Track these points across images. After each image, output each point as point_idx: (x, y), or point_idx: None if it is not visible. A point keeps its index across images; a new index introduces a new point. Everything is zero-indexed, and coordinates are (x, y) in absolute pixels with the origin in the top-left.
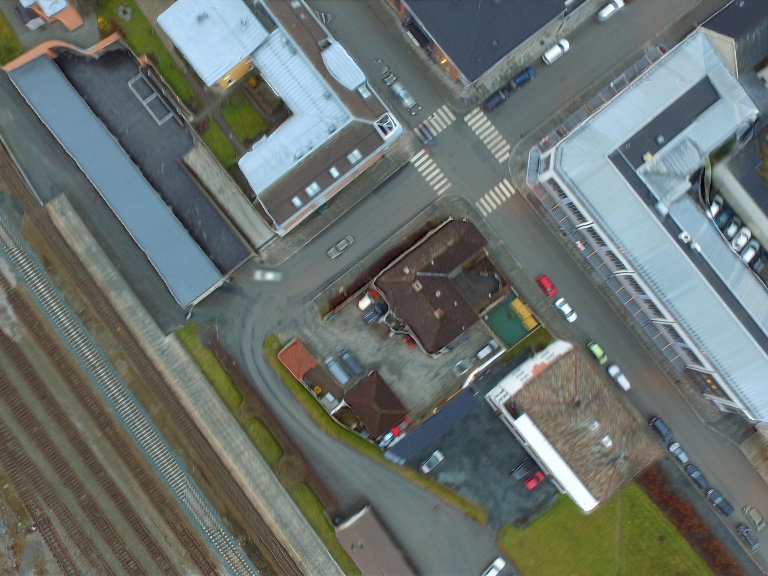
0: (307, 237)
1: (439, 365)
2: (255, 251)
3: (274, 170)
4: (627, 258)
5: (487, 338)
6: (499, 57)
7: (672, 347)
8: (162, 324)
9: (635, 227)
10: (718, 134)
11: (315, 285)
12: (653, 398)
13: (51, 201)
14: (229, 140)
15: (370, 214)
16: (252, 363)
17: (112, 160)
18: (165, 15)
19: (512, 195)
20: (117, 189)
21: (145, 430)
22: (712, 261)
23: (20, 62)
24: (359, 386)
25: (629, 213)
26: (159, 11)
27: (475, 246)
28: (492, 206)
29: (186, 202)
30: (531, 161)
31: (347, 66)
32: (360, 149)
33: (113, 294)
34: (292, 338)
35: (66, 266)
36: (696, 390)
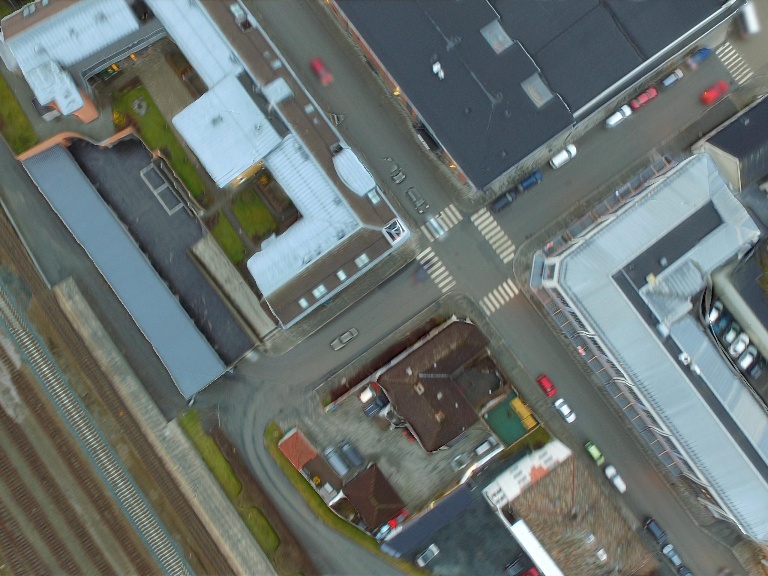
0: (311, 328)
1: (438, 459)
2: (259, 340)
3: (282, 273)
4: (627, 372)
5: (486, 435)
6: (507, 167)
7: (669, 454)
8: (164, 410)
9: (636, 345)
10: (720, 255)
11: (318, 375)
12: (648, 499)
13: (59, 284)
14: (238, 235)
15: (375, 308)
16: (252, 451)
17: (122, 251)
18: (180, 116)
19: (515, 295)
20: (125, 280)
21: (143, 515)
22: (711, 382)
23: (34, 152)
24: (358, 479)
25: (631, 331)
26: (174, 106)
27: (478, 348)
28: (495, 305)
29: (193, 292)
30: (535, 265)
31: (358, 173)
32: (368, 253)
33: (117, 379)
34: (293, 427)
35: (71, 349)
36: (691, 493)
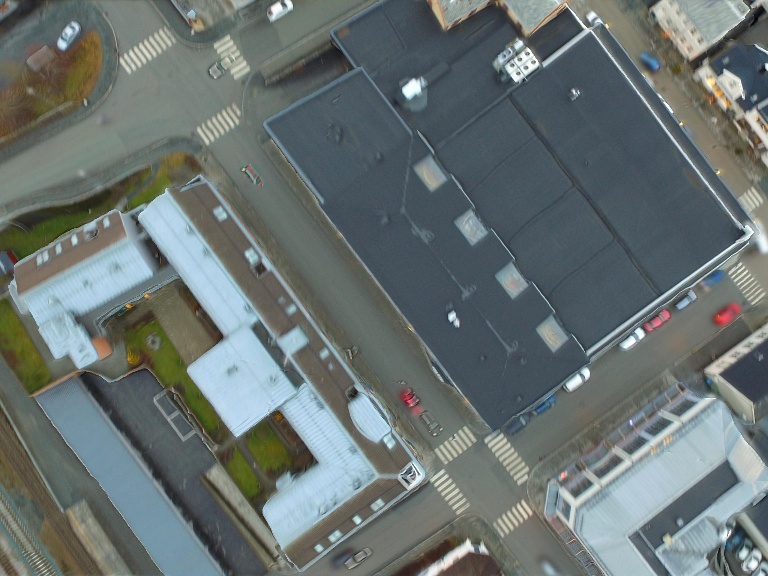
0: None
1: None
2: (273, 560)
3: (298, 521)
4: None
5: None
6: (523, 409)
7: None
8: None
9: None
10: (735, 506)
11: None
12: None
13: (72, 507)
14: (253, 470)
15: (389, 529)
16: None
17: (135, 485)
18: (195, 366)
19: (529, 517)
20: (140, 515)
21: None
22: None
23: None
24: None
25: None
26: (187, 340)
27: None
28: (509, 527)
29: (207, 518)
30: (550, 494)
31: (373, 420)
32: (383, 498)
33: None
34: None
35: (84, 572)
36: None
